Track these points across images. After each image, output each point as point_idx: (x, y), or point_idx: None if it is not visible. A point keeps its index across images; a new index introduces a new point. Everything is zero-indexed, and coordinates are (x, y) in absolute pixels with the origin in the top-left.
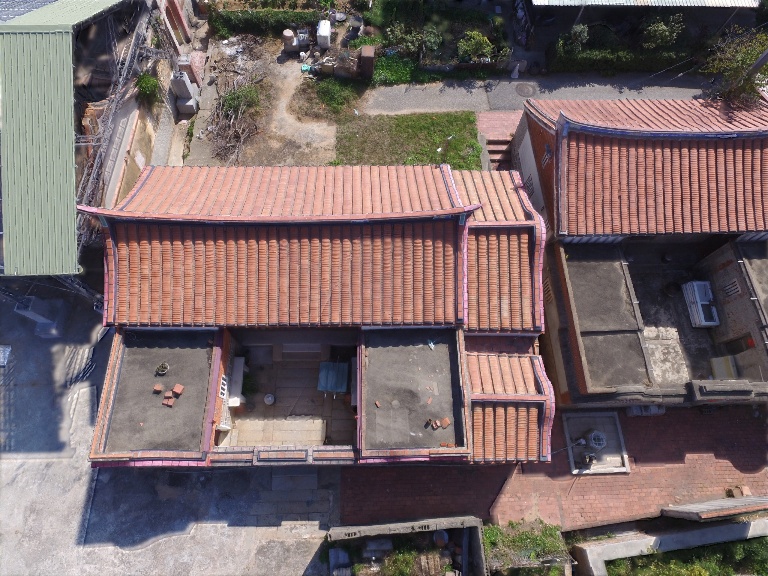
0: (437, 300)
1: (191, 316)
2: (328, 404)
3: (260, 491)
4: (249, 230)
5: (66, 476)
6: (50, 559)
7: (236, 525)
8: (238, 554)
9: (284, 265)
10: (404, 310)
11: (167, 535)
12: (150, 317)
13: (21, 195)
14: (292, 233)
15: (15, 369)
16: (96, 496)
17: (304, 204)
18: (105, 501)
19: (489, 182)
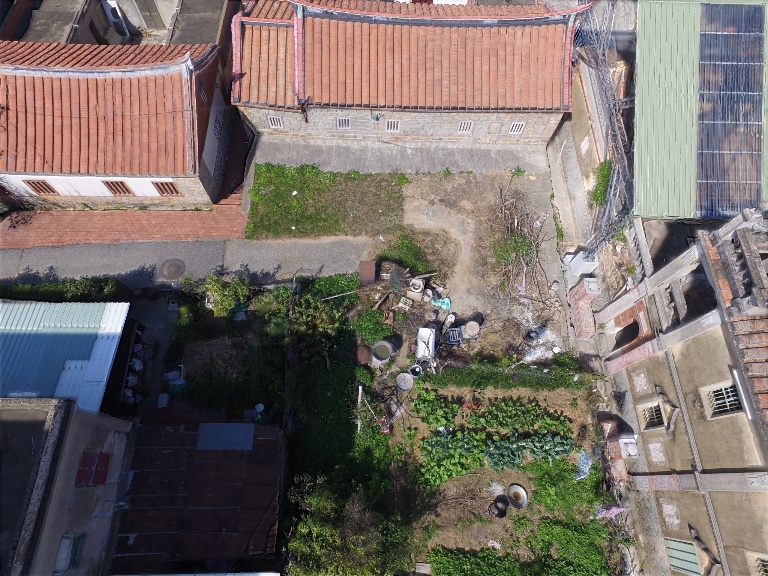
0: (325, 2)
1: None
2: None
3: None
4: None
5: None
6: None
7: None
8: None
9: None
10: (349, 2)
11: None
12: None
13: None
14: None
15: None
16: None
17: (425, 50)
18: None
19: (263, 85)
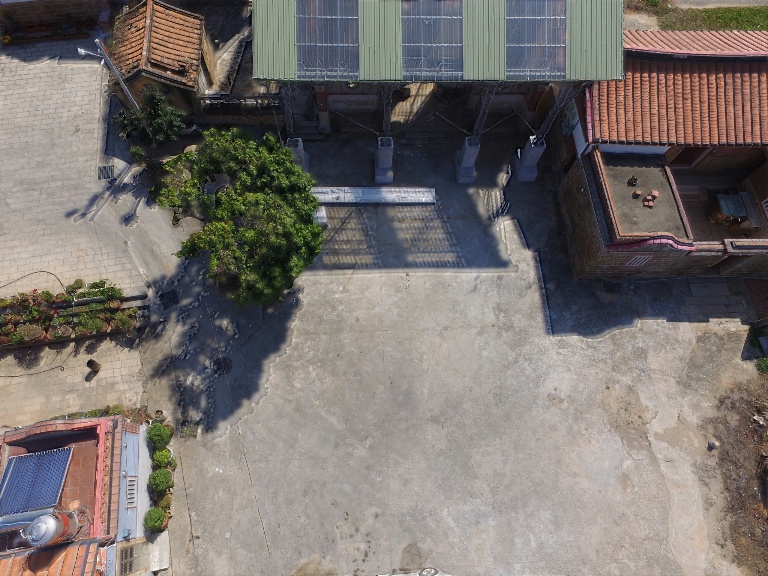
0: None
1: (658, 136)
2: (716, 233)
3: (683, 297)
4: (702, 65)
5: (518, 285)
6: (529, 345)
7: (673, 321)
8: (682, 342)
9: (730, 95)
10: None
11: (619, 328)
12: (625, 136)
13: (581, 14)
14: (736, 68)
15: (443, 206)
16: (549, 300)
17: None
18: (558, 303)
19: None
